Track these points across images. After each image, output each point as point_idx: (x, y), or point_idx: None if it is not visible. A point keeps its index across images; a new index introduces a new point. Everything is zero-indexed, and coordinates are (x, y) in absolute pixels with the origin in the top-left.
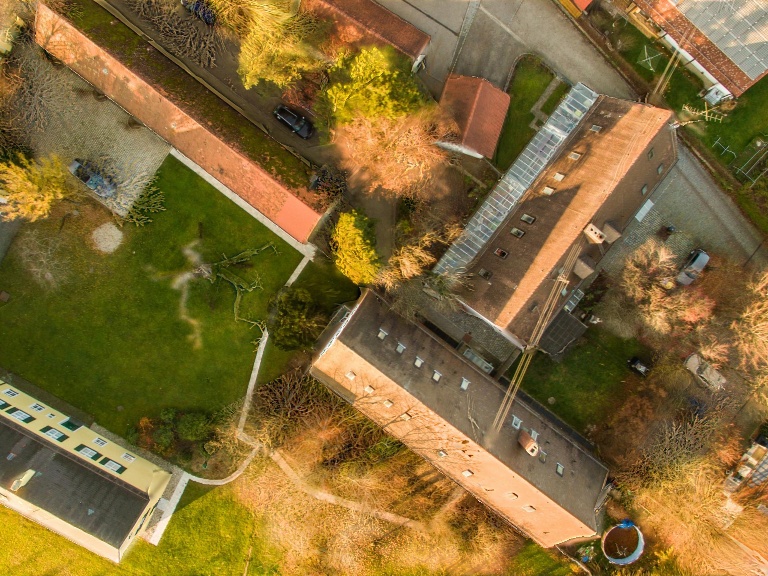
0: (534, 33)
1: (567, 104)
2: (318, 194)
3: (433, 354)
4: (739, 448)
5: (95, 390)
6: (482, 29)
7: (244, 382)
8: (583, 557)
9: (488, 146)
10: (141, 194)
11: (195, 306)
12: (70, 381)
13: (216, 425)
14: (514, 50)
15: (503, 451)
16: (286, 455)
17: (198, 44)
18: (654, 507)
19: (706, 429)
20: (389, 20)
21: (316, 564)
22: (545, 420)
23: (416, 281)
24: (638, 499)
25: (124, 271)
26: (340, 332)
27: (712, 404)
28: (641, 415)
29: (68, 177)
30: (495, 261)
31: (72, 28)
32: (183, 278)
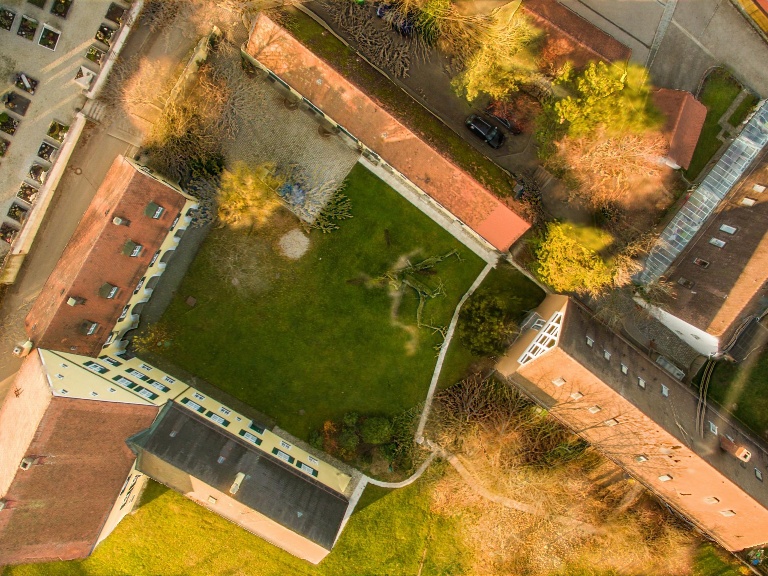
0: (723, 46)
1: (761, 117)
2: (523, 203)
3: (633, 361)
4: None
5: (278, 394)
6: (673, 42)
7: (424, 387)
8: (754, 560)
9: (686, 157)
10: (329, 201)
11: (379, 312)
12: (254, 385)
13: (397, 429)
14: (704, 63)
15: (712, 457)
16: (464, 459)
17: (391, 54)
18: None
19: None
20: (594, 33)
21: (490, 566)
22: (735, 426)
23: (627, 290)
24: None
25: (310, 277)
26: (550, 339)
27: None
28: None
29: (257, 184)
30: (696, 270)
31: (292, 39)
32: (368, 284)
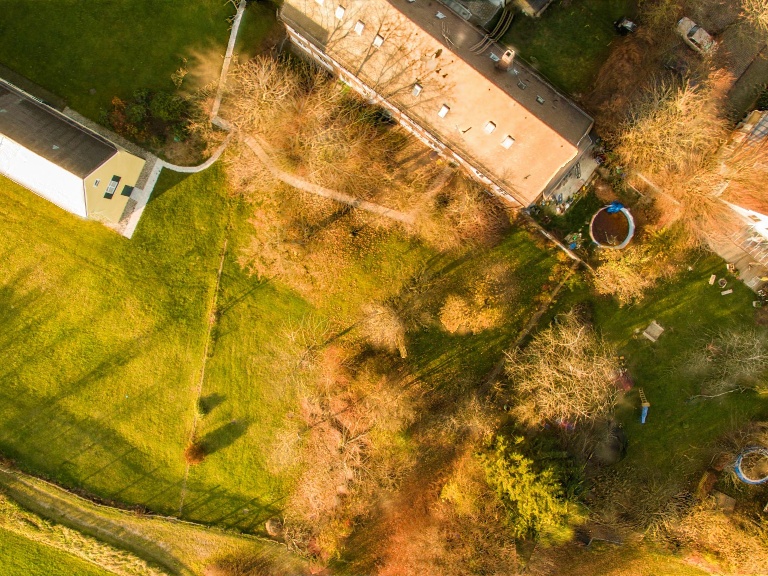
0: None
1: None
2: None
3: None
4: (734, 118)
5: (67, 72)
6: None
7: (218, 63)
8: (570, 244)
9: None
10: None
11: None
12: (42, 63)
13: (190, 106)
14: None
15: (478, 65)
16: (261, 139)
17: None
18: (644, 187)
19: (698, 100)
20: None
21: (293, 257)
22: (526, 68)
23: None
24: (627, 177)
25: None
26: None
27: (704, 71)
28: (627, 57)
29: None
30: None
31: None
32: None
